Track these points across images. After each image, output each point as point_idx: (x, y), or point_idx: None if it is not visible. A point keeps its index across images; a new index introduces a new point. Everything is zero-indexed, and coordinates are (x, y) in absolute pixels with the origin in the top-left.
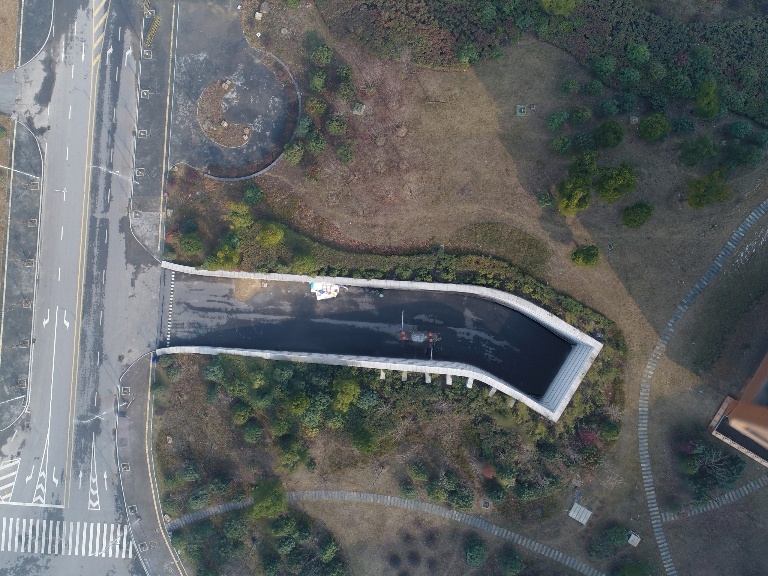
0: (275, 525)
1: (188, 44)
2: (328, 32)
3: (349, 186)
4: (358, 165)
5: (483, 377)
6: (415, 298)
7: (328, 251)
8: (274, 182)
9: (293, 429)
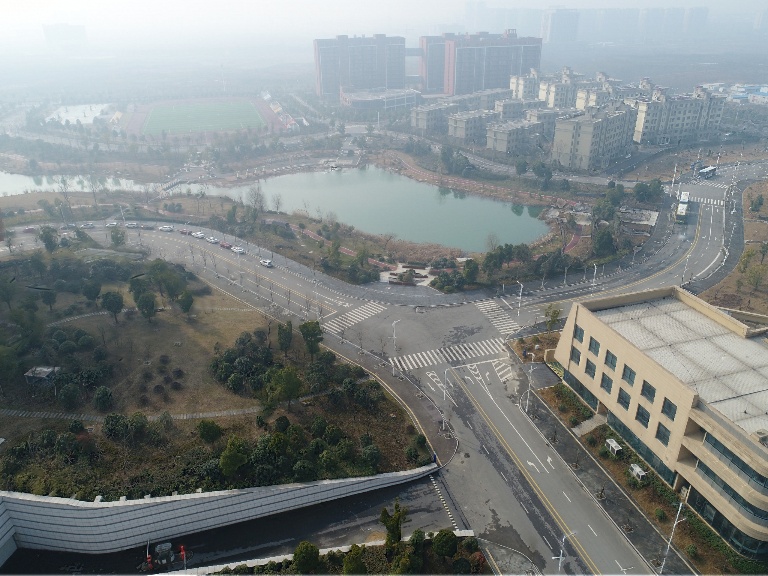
0: None
1: None
2: None
3: None
4: None
5: (82, 504)
6: None
7: None
8: None
9: None
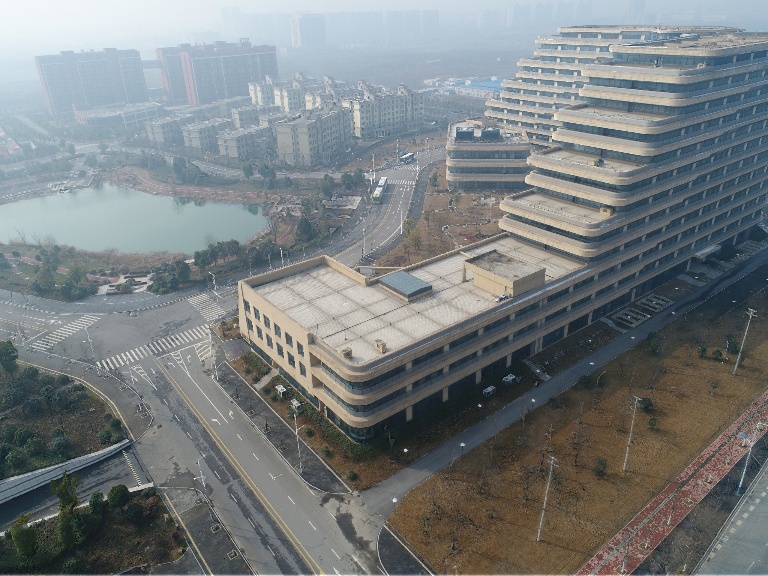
0: None
1: None
2: None
3: None
4: None
5: None
6: None
7: None
8: None
9: None
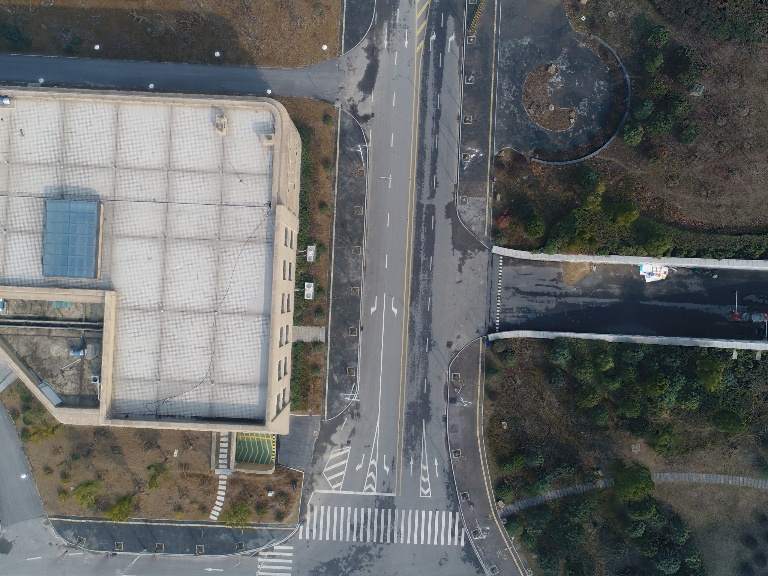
0: (636, 507)
1: (511, 29)
2: (656, 14)
3: (689, 167)
4: (698, 146)
5: None
6: (744, 279)
7: (675, 232)
8: (606, 165)
9: (642, 411)
